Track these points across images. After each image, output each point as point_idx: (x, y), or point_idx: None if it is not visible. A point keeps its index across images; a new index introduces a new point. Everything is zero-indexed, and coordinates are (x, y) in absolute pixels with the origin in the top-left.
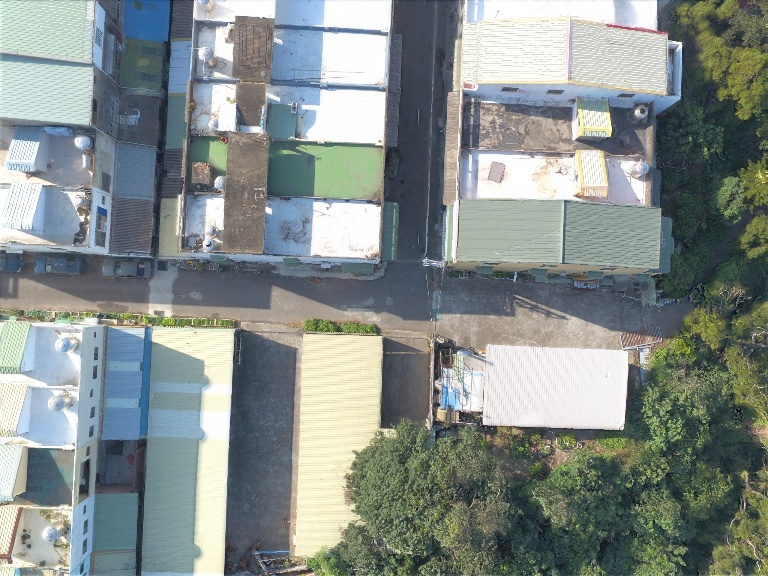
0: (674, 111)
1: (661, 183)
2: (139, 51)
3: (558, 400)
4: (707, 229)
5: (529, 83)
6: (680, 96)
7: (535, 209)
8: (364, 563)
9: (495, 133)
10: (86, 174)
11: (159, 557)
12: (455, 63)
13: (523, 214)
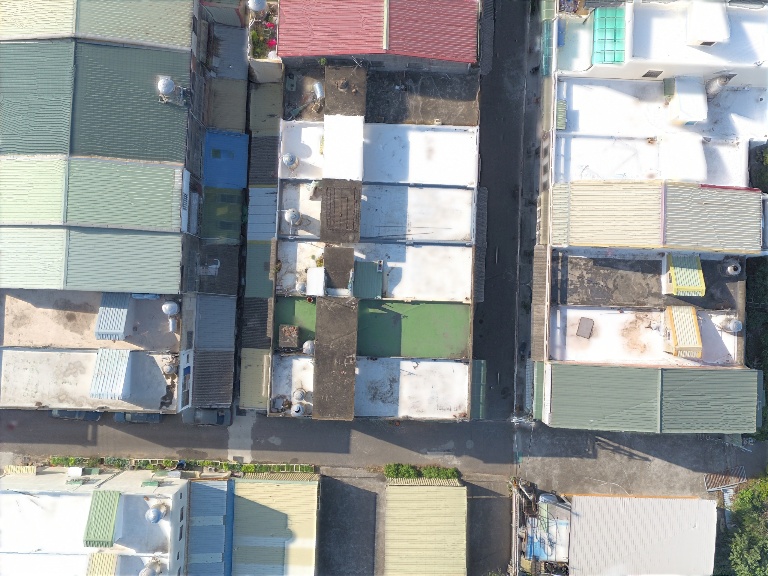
0: (763, 258)
1: (746, 324)
2: (218, 200)
3: (645, 551)
4: None
5: (622, 246)
6: None
7: (630, 376)
8: None
9: (583, 288)
10: (172, 336)
11: None
12: (541, 216)
13: (618, 381)
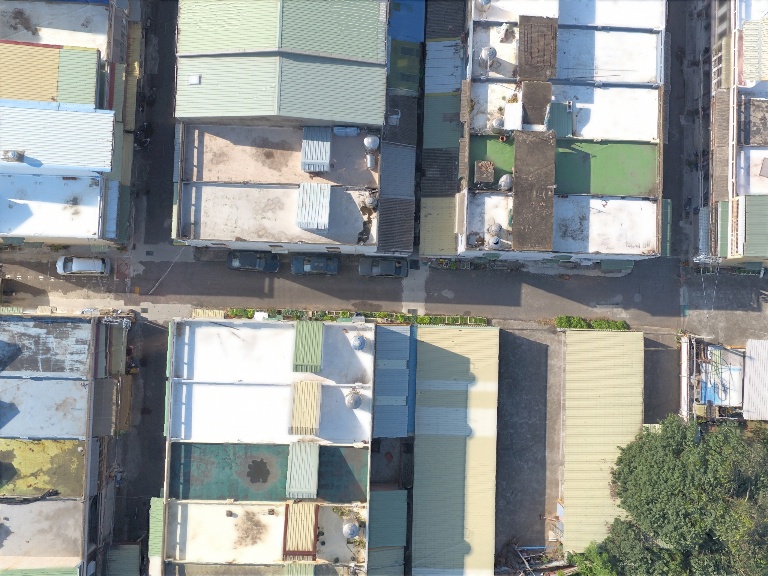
0: None
1: None
2: (399, 52)
3: None
4: None
5: None
6: None
7: None
8: (639, 557)
9: (766, 129)
10: (368, 174)
11: (429, 553)
12: (723, 61)
13: None
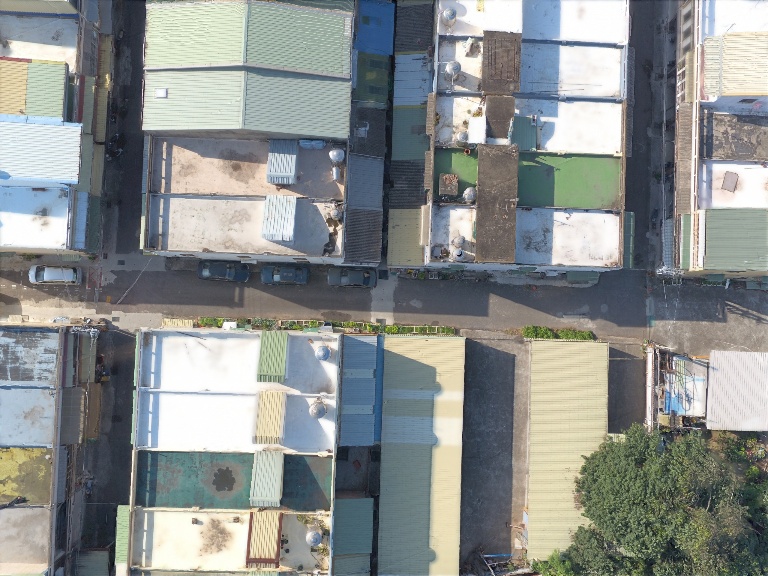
0: None
1: None
2: (367, 65)
3: None
4: None
5: None
6: None
7: None
8: (601, 566)
9: (728, 143)
10: (334, 186)
11: (395, 561)
12: (686, 75)
13: None
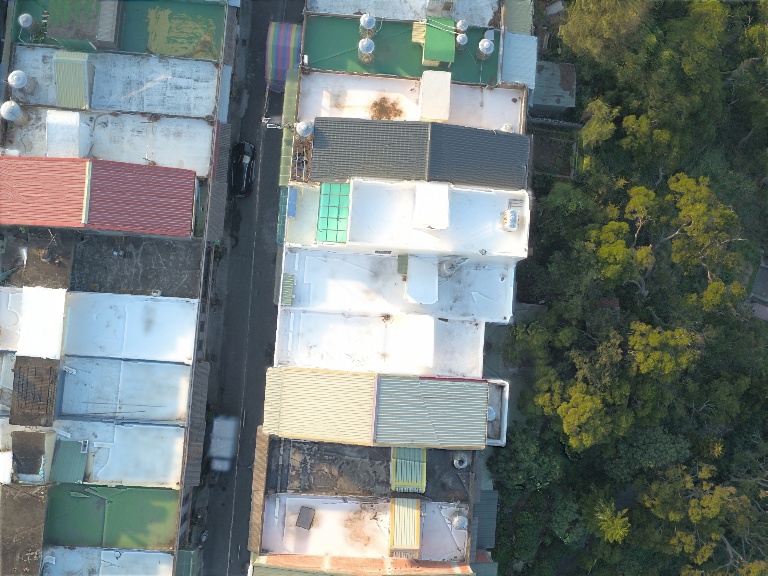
0: None
1: (499, 503)
2: None
3: None
4: (551, 545)
5: None
6: (504, 443)
7: None
8: None
9: (305, 475)
10: None
11: None
12: None
13: None
